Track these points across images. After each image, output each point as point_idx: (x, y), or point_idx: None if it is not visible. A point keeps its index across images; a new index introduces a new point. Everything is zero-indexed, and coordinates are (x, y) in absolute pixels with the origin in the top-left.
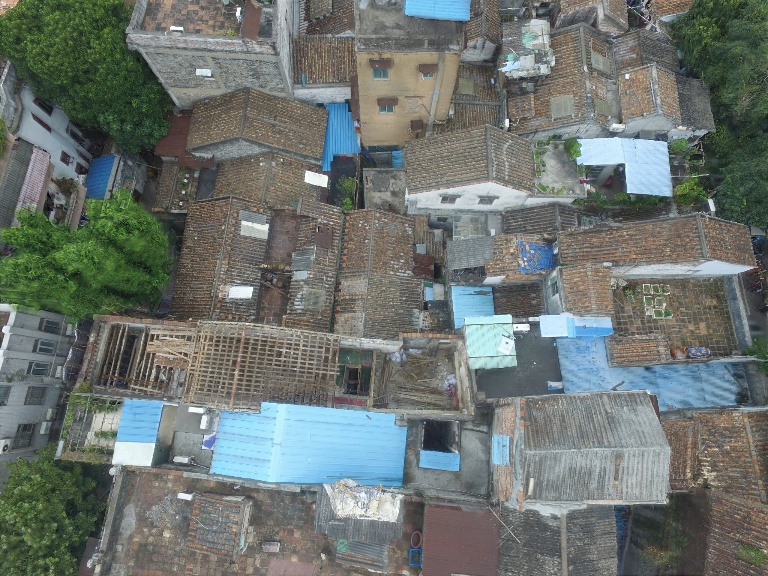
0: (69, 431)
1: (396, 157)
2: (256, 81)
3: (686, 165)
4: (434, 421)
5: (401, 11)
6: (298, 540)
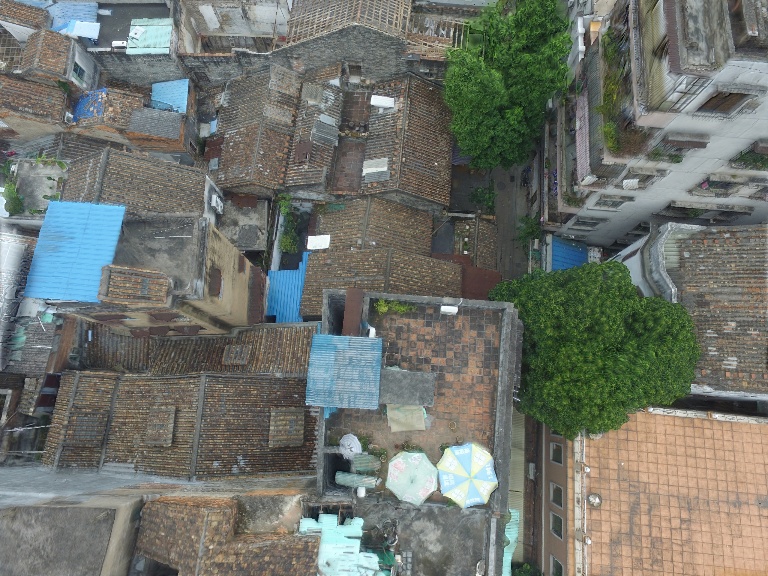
0: None
1: None
2: None
3: None
4: None
5: None
6: None
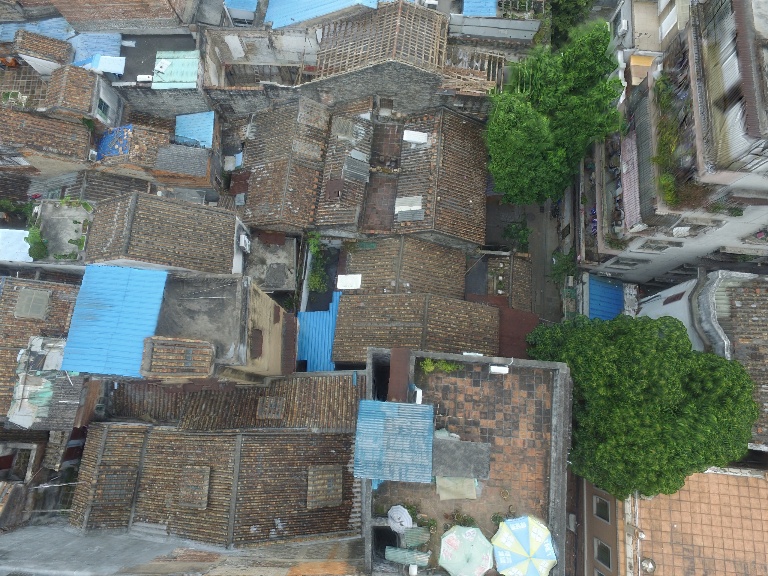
0: None
1: None
2: None
3: None
4: None
5: None
6: None
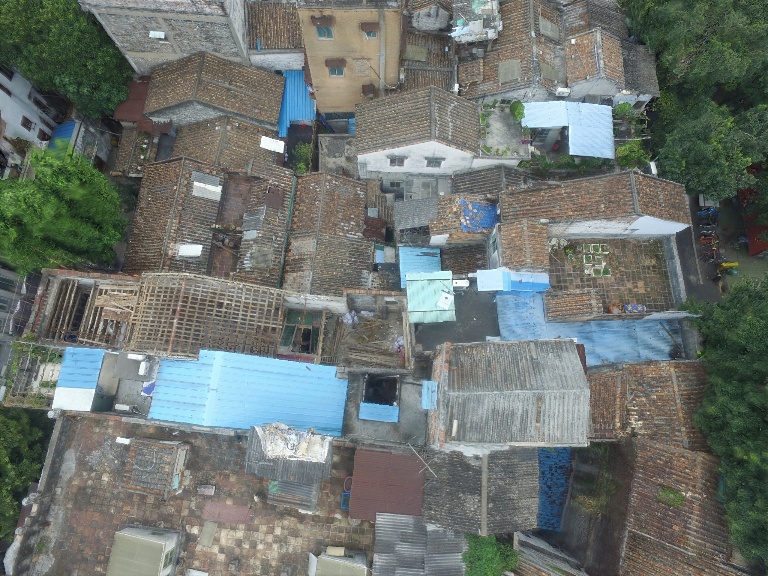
0: (14, 380)
1: (352, 124)
2: (210, 45)
3: (632, 130)
4: (383, 381)
5: None
6: (234, 484)
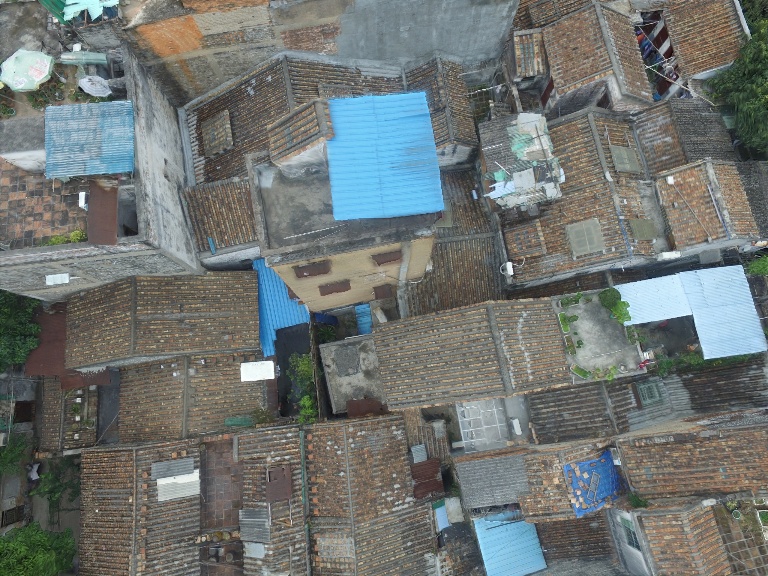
0: None
1: (361, 314)
2: (141, 270)
3: (767, 284)
4: None
5: (328, 180)
6: None
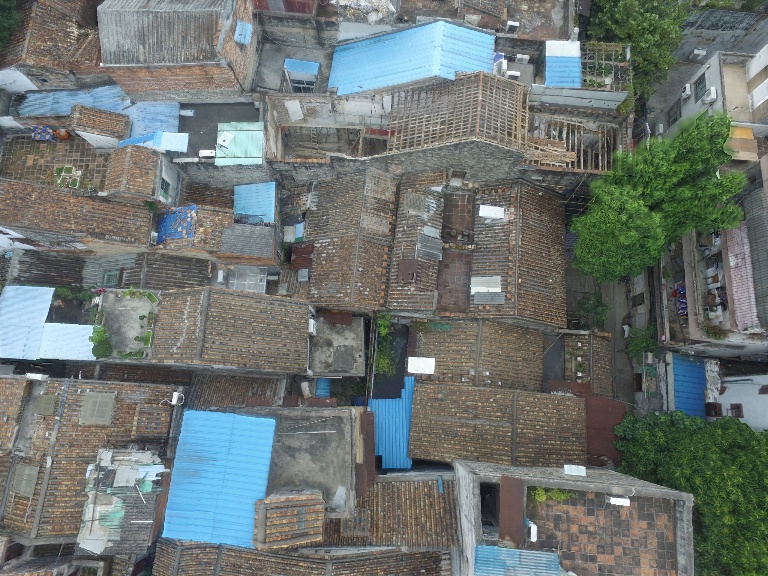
0: None
1: None
2: None
3: None
4: None
5: (286, 481)
6: (418, 2)
